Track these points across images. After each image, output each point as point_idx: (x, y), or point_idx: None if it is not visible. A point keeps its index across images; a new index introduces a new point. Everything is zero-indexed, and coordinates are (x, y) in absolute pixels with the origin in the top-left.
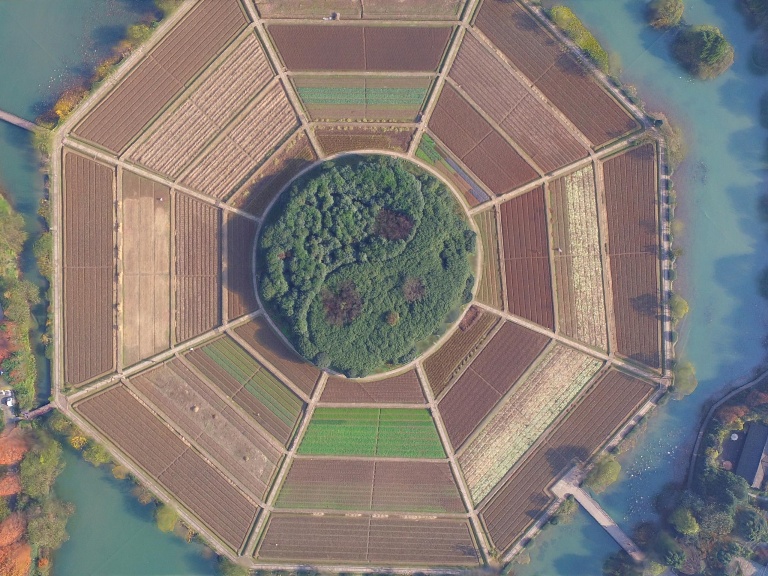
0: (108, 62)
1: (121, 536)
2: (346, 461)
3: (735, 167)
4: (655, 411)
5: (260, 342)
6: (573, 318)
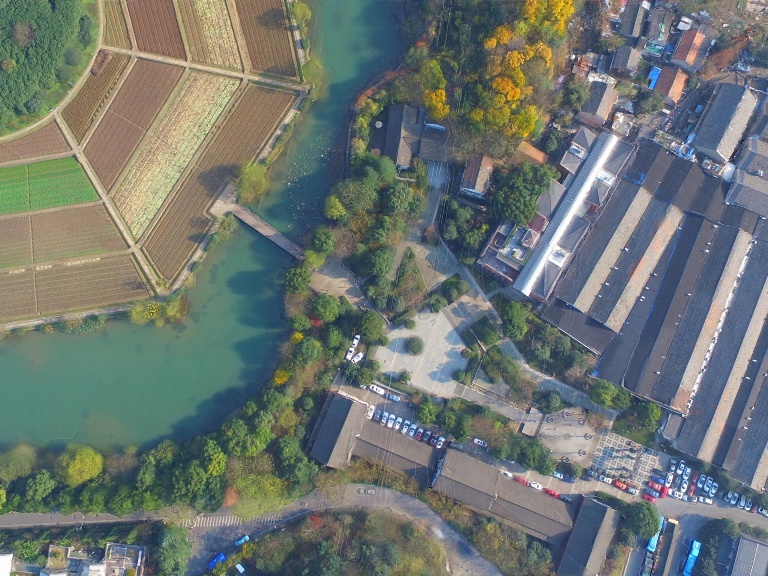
0: None
1: None
2: (1, 221)
3: None
4: (299, 117)
5: None
6: (203, 45)
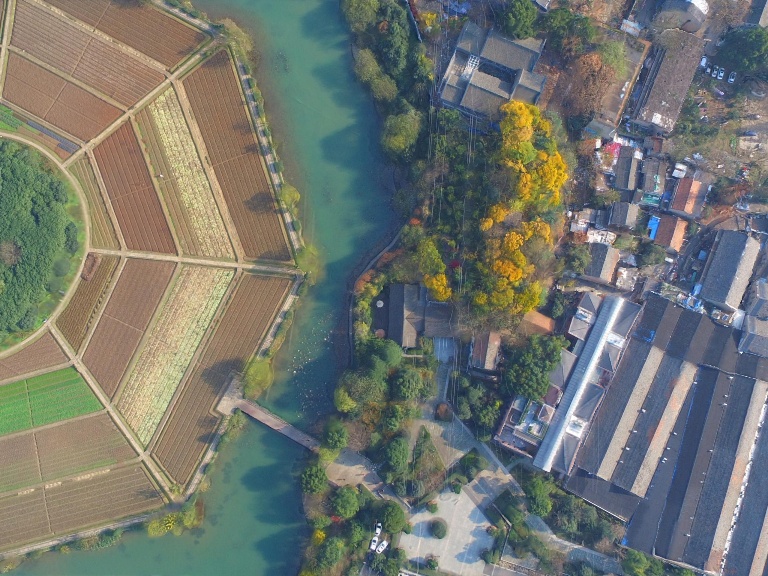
0: None
1: None
2: (5, 441)
3: (314, 48)
4: (298, 302)
5: None
6: (193, 237)
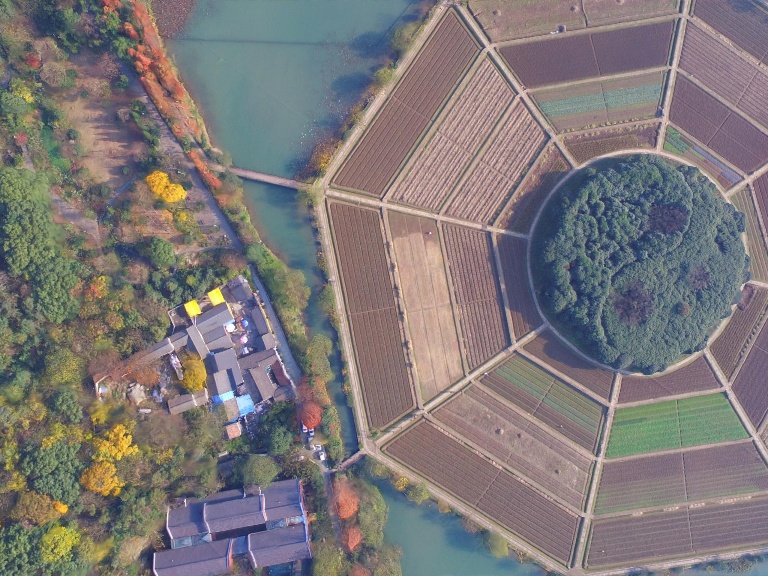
0: (354, 110)
1: (450, 570)
2: (654, 457)
3: None
4: None
5: (550, 355)
6: None
